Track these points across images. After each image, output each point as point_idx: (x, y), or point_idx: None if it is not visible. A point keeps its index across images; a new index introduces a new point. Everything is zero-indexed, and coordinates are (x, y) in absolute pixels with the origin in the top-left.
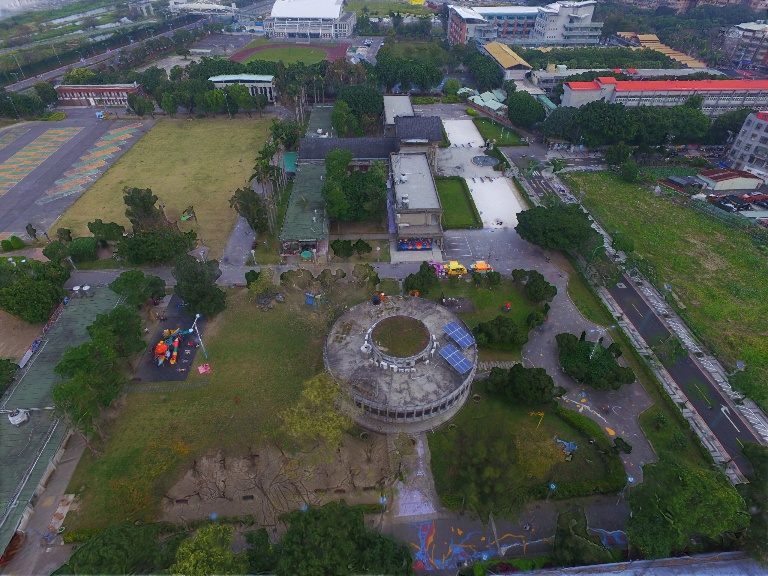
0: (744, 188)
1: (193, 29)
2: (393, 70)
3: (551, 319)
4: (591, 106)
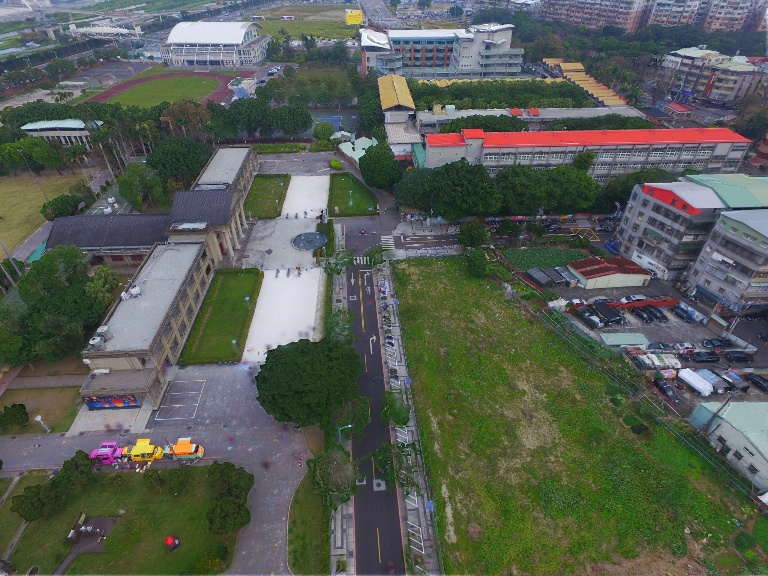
0: (626, 285)
1: (88, 56)
2: (245, 114)
3: (234, 566)
4: (444, 170)
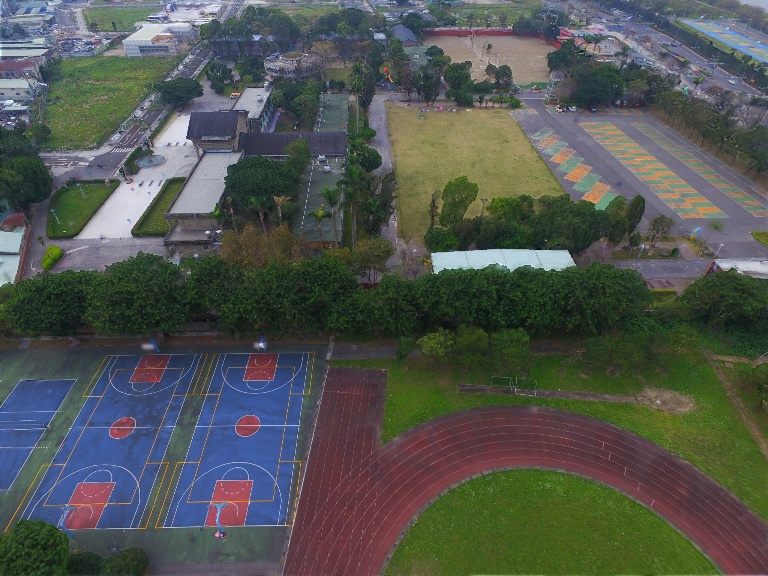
0: None
1: None
2: None
3: None
4: None
